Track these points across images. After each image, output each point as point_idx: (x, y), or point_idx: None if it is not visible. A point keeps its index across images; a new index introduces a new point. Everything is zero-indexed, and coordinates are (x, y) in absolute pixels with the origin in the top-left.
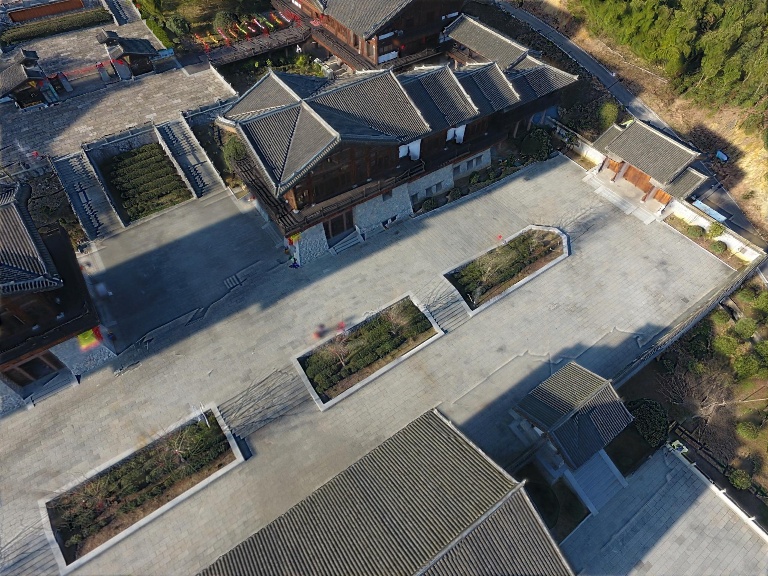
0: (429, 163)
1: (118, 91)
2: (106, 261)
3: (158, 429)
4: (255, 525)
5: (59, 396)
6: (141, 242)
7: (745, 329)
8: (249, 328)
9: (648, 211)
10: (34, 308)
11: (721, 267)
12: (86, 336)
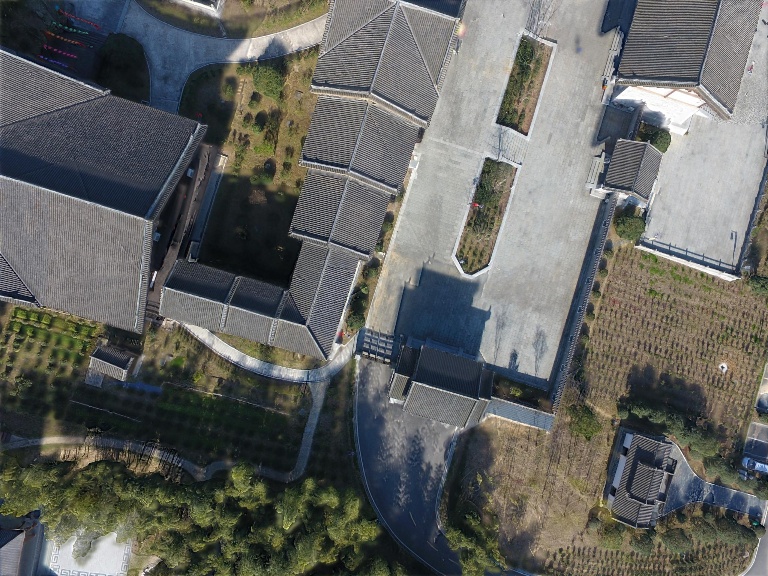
0: None
1: None
2: None
3: (509, 59)
4: (586, 65)
5: None
6: None
7: None
8: None
9: None
10: None
11: None
12: None
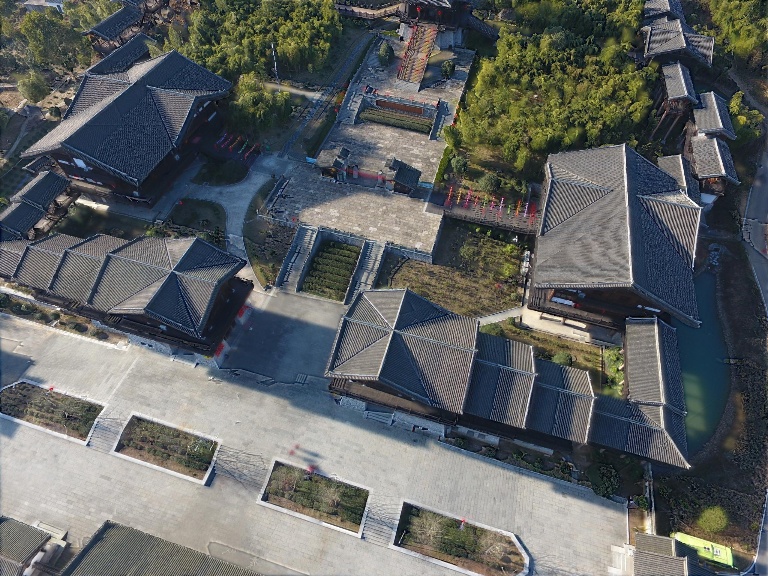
0: (467, 423)
1: (377, 196)
2: (268, 306)
3: (193, 428)
4: (175, 522)
5: (184, 366)
6: (292, 309)
7: None
8: (278, 416)
9: None
10: None
11: None
12: None
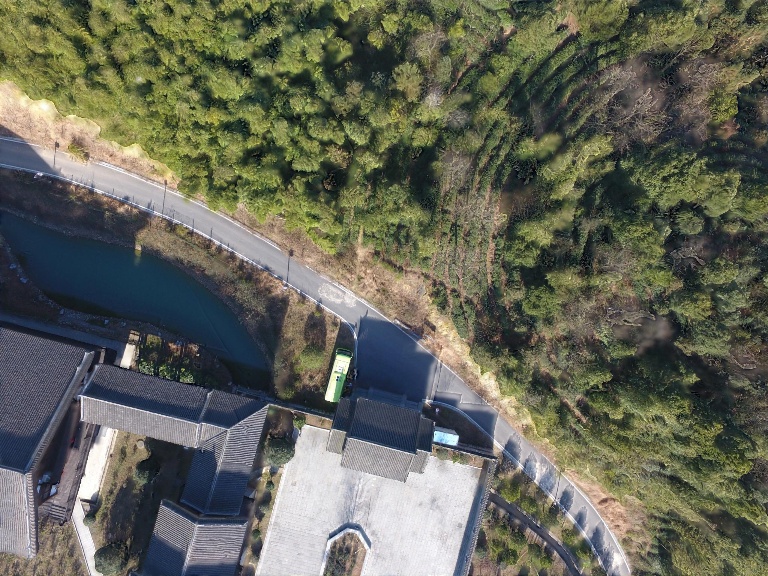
0: None
1: None
2: None
3: None
4: None
5: None
6: None
7: None
8: None
9: None
10: None
11: (471, 473)
12: None
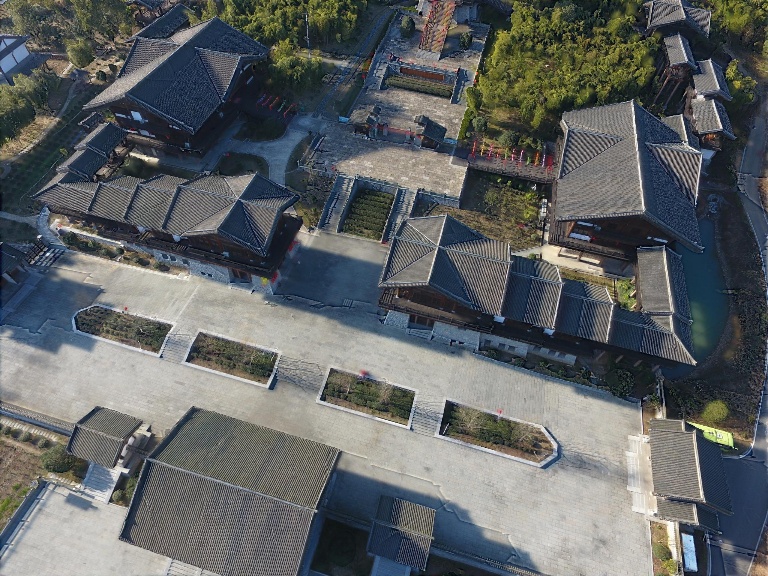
0: (502, 331)
1: (406, 151)
2: (313, 244)
3: (255, 342)
4: (245, 418)
5: (241, 293)
6: (335, 246)
7: None
8: (329, 333)
9: (646, 503)
10: (255, 254)
11: None
12: (264, 279)
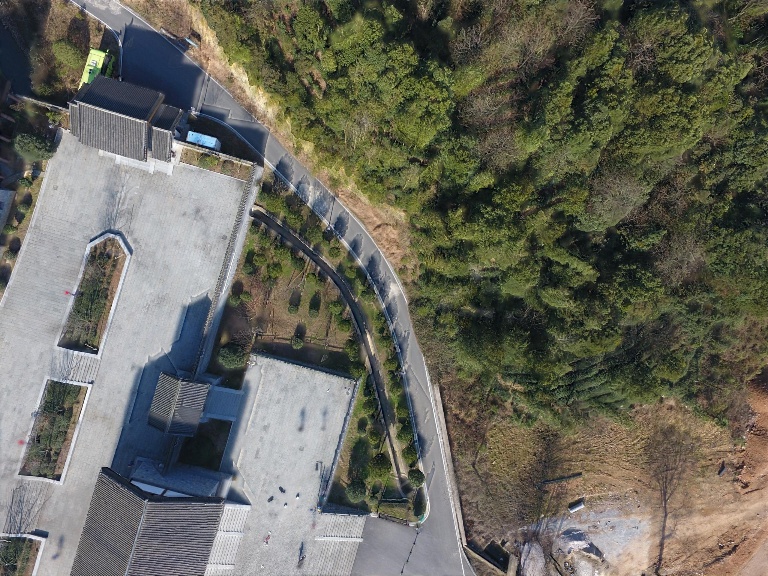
0: None
1: None
2: None
3: None
4: None
5: None
6: None
7: (262, 245)
8: None
9: None
10: None
11: (236, 185)
12: None
